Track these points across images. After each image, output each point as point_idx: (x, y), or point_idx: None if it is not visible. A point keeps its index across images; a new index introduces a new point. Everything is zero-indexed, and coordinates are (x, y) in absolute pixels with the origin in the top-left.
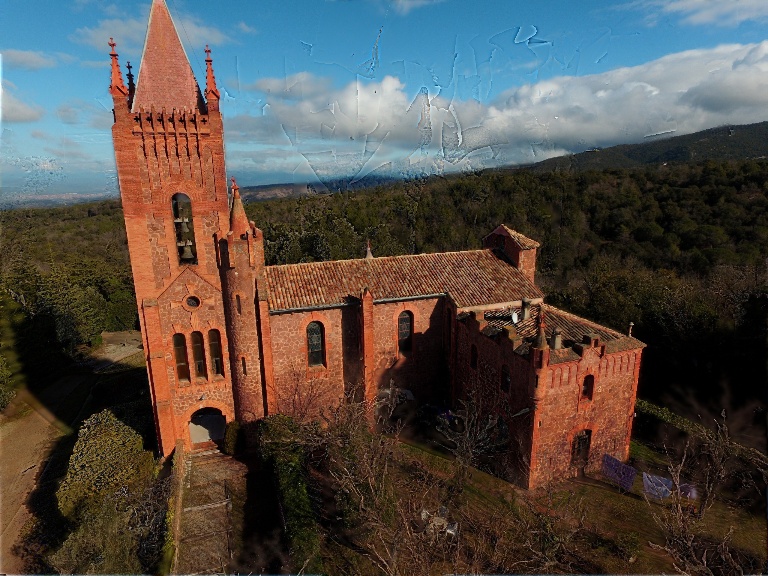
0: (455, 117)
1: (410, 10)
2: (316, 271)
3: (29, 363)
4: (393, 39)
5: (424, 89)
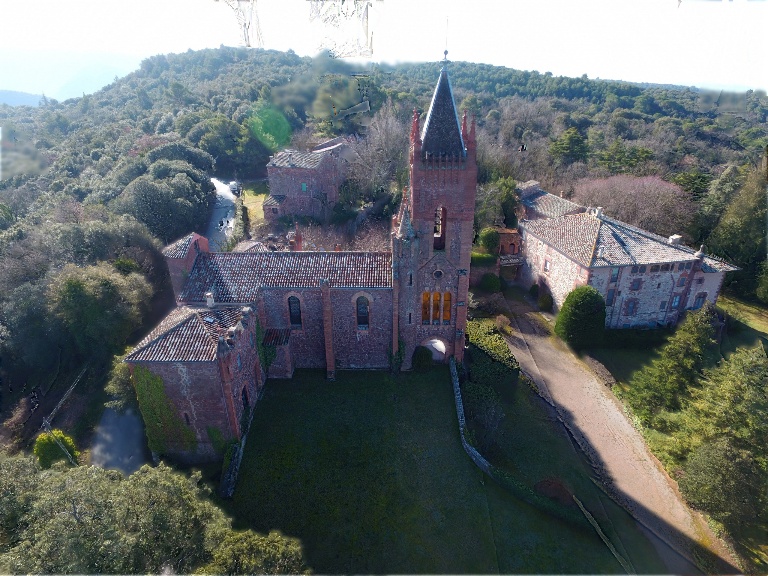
0: (4, 140)
1: (302, 87)
2: None
3: None
4: (312, 103)
5: (344, 139)
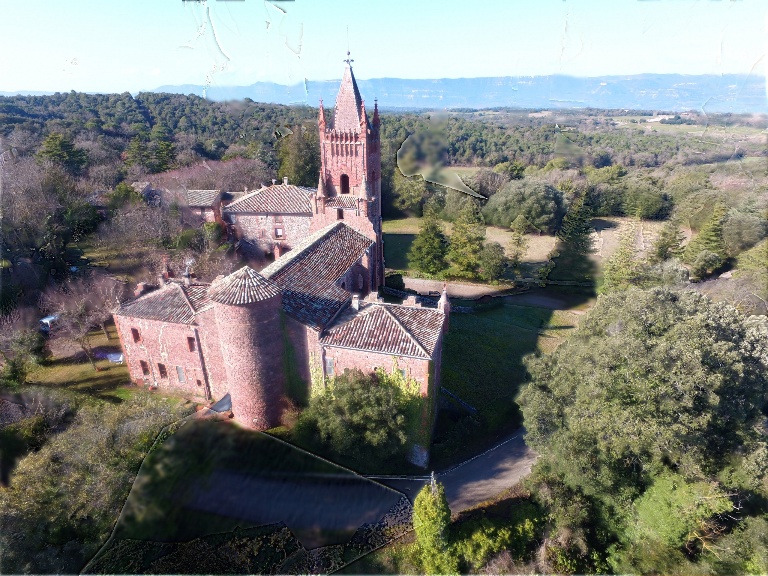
0: None
1: None
2: (321, 234)
3: (551, 277)
4: None
5: None
